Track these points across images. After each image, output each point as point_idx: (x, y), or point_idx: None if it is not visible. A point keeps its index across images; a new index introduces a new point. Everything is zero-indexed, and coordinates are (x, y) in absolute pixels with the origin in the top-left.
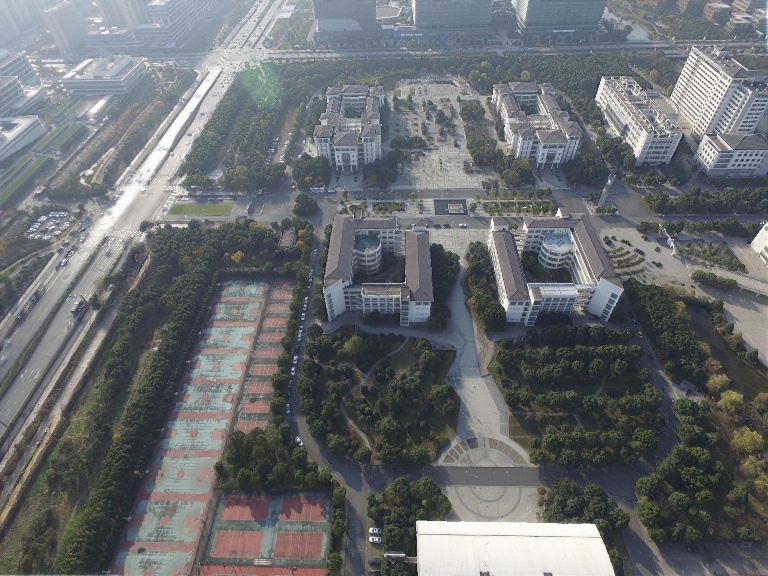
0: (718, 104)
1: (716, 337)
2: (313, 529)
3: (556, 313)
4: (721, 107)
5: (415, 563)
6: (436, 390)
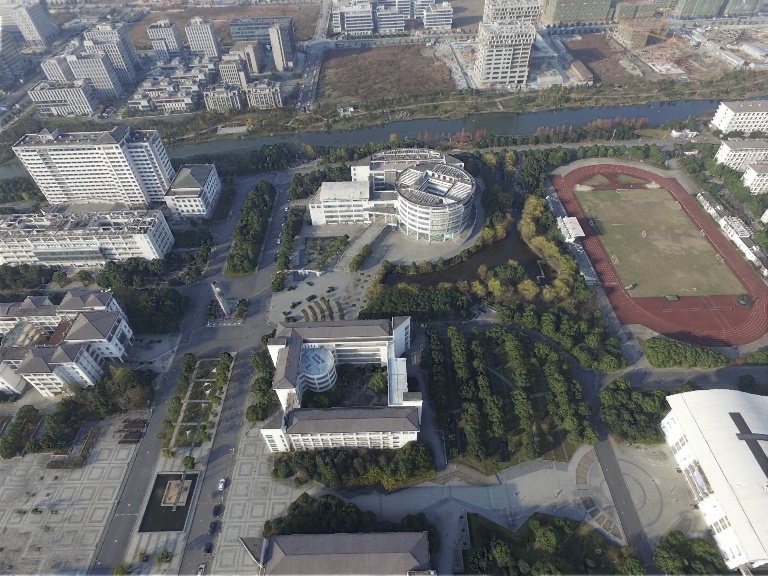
0: (130, 170)
1: (419, 277)
2: None
3: None
4: (134, 171)
5: (752, 574)
6: (554, 539)
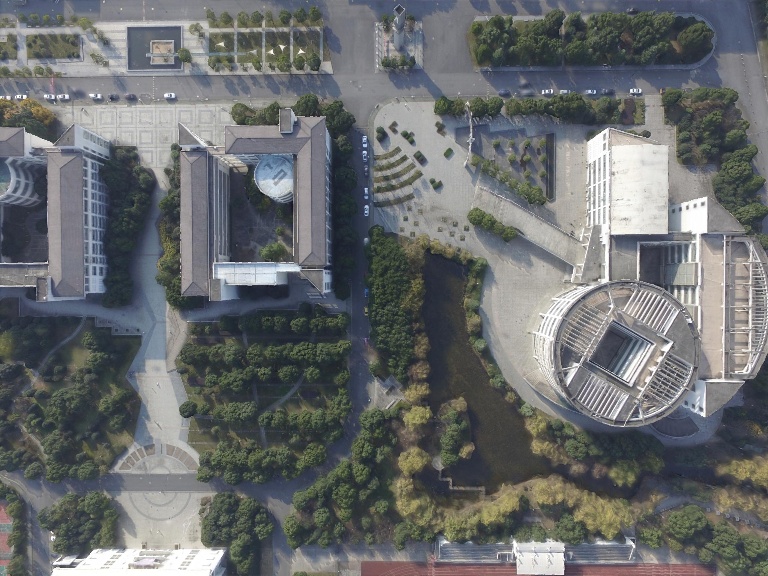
0: None
1: (458, 312)
2: (1, 530)
3: (265, 286)
4: None
5: None
6: None
